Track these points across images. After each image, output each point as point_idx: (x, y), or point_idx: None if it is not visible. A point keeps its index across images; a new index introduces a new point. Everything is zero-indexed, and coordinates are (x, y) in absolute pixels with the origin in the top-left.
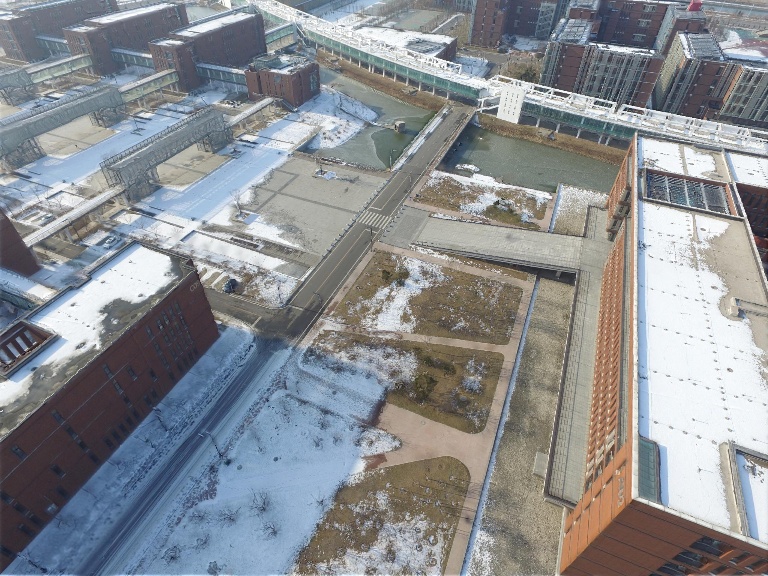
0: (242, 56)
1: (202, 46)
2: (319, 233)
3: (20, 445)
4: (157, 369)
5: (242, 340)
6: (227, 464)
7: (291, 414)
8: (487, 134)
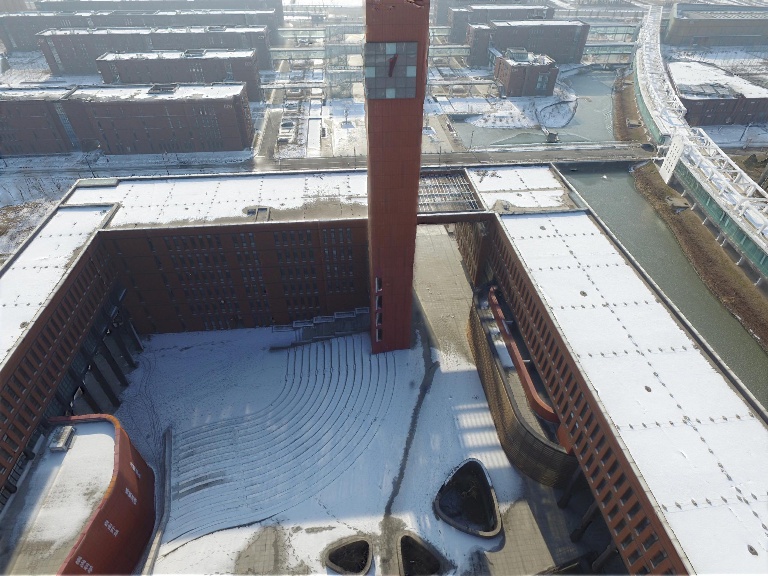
0: None
1: (503, 35)
2: (356, 148)
3: (123, 109)
4: (194, 133)
5: (243, 157)
6: None
7: None
8: (621, 178)
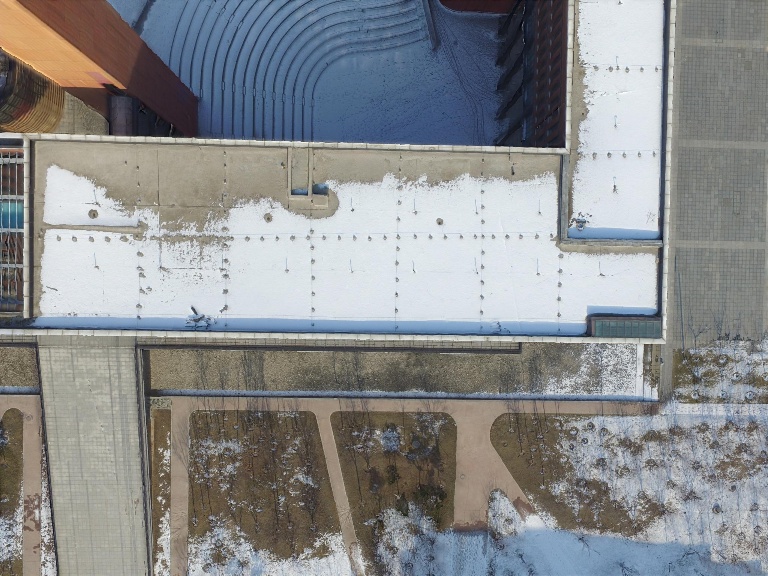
0: None
1: None
2: None
3: None
4: None
5: None
6: None
7: None
8: None
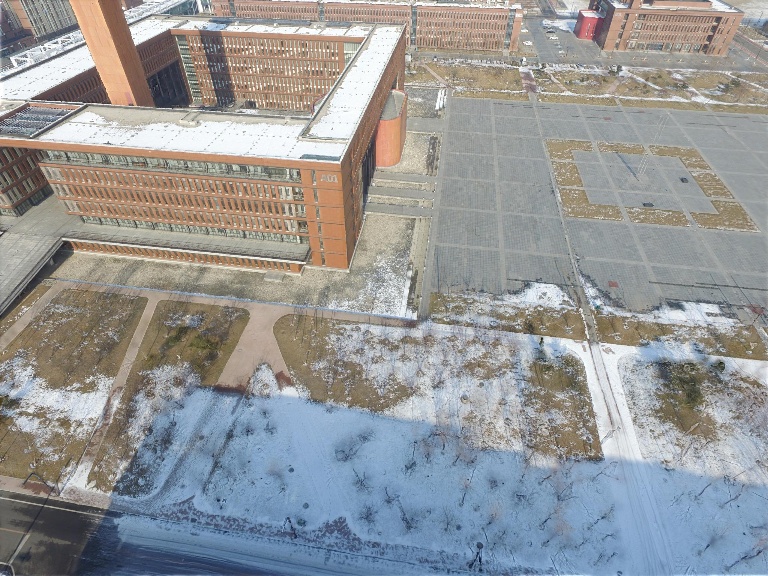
0: None
1: None
2: None
3: None
4: None
5: None
6: (304, 523)
7: (234, 473)
8: None
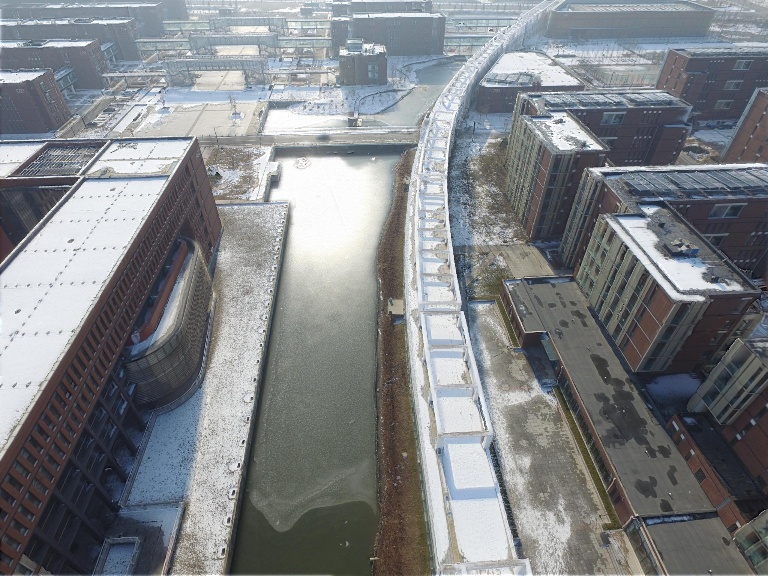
0: (407, 47)
1: (360, 27)
2: (155, 132)
3: None
4: None
5: None
6: None
7: None
8: (388, 160)
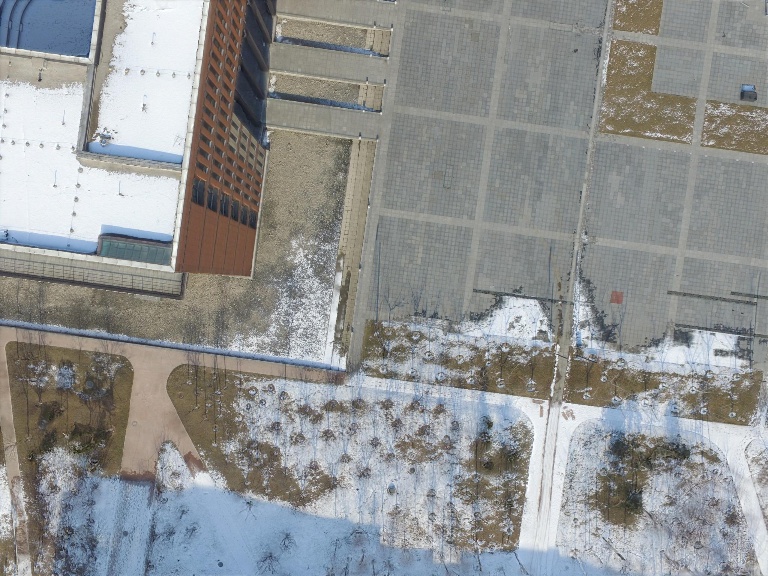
0: None
1: None
2: None
3: None
4: None
5: None
6: None
7: (167, 572)
8: None
